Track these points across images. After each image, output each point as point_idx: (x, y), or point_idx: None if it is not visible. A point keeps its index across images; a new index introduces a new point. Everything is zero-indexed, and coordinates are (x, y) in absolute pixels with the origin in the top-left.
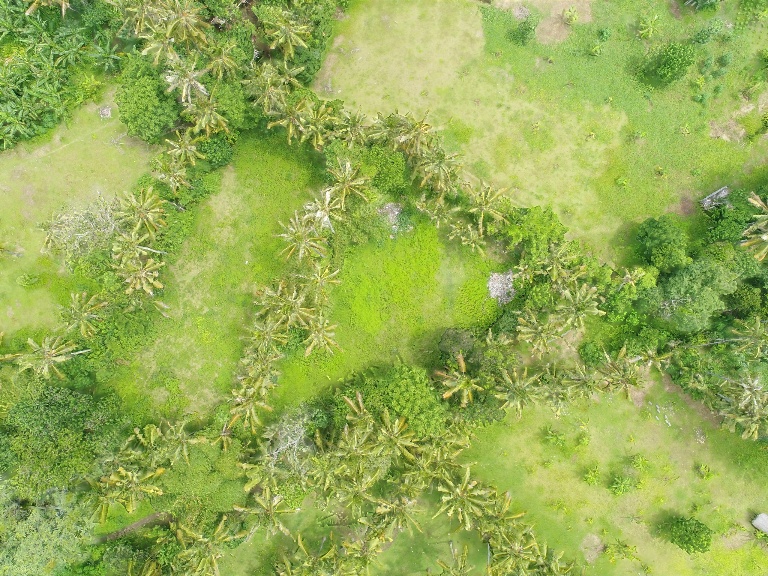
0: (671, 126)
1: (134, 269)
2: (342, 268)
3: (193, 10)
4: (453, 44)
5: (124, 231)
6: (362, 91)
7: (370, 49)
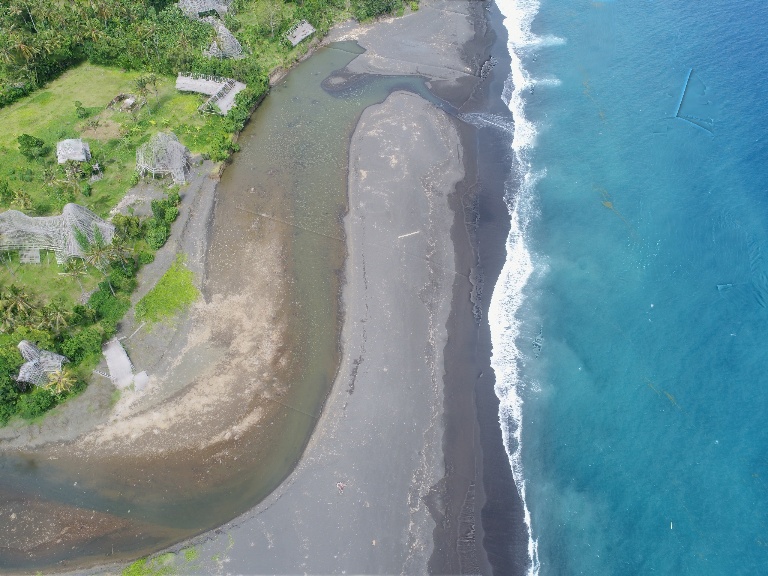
0: (3, 163)
1: (16, 4)
2: (2, 74)
3: (104, 6)
4: (91, 99)
5: (31, 0)
6: (82, 77)
7: (101, 79)
